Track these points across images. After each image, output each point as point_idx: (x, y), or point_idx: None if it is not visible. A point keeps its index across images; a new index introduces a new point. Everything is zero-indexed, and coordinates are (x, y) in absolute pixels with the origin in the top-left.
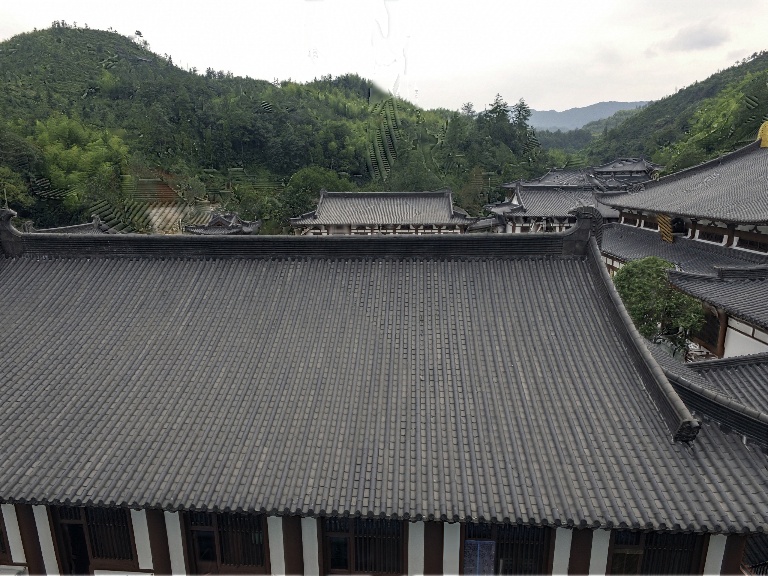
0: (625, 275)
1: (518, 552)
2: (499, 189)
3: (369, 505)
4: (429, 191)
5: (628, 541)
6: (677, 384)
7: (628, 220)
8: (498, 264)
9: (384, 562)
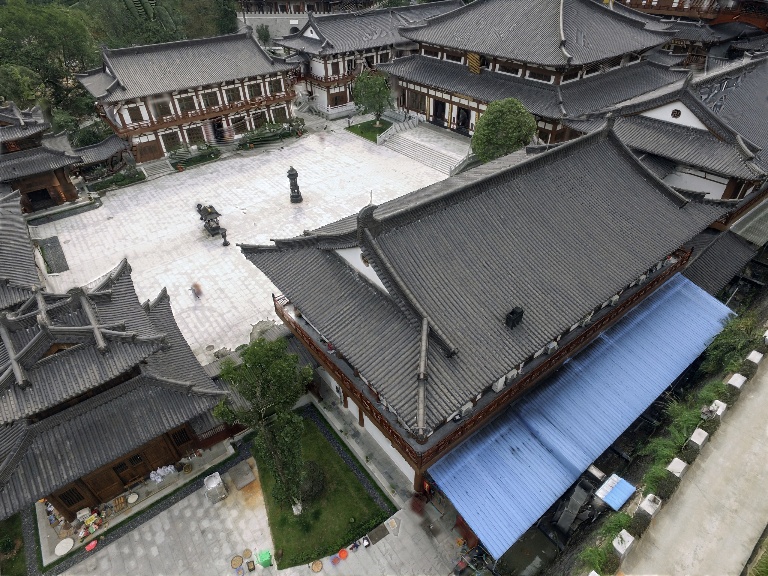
0: (499, 114)
1: None
2: (227, 2)
3: (651, 263)
4: (230, 33)
5: None
6: None
7: (429, 52)
8: (584, 152)
9: None
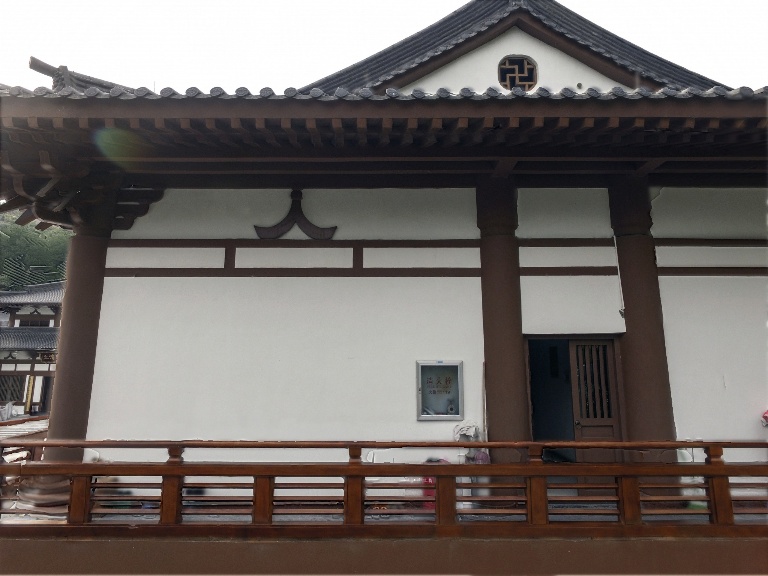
0: None
1: None
2: None
3: None
4: None
5: None
6: None
7: (30, 322)
8: None
9: None
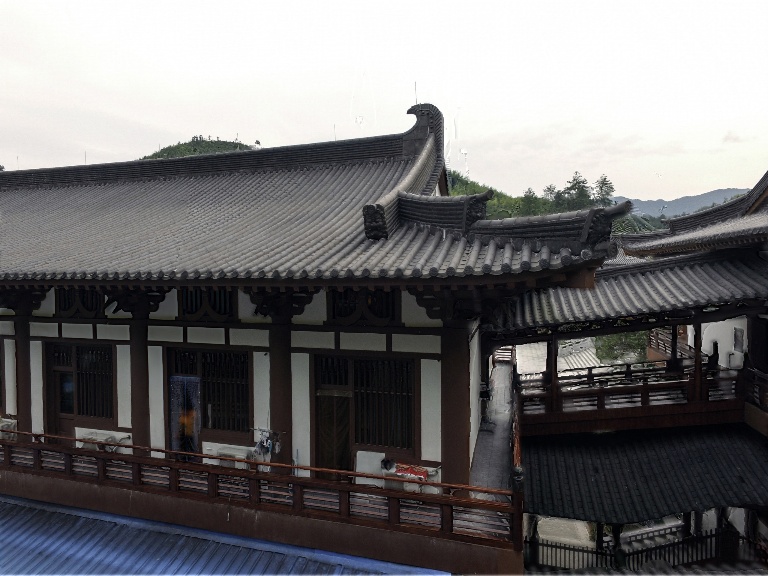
0: None
1: (225, 393)
2: None
3: None
4: None
5: (337, 380)
6: (404, 199)
7: None
8: (340, 169)
9: (102, 404)
